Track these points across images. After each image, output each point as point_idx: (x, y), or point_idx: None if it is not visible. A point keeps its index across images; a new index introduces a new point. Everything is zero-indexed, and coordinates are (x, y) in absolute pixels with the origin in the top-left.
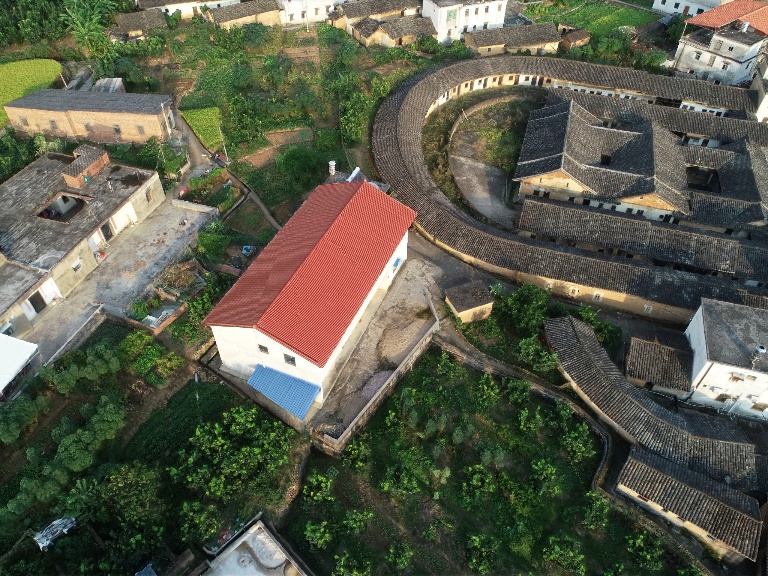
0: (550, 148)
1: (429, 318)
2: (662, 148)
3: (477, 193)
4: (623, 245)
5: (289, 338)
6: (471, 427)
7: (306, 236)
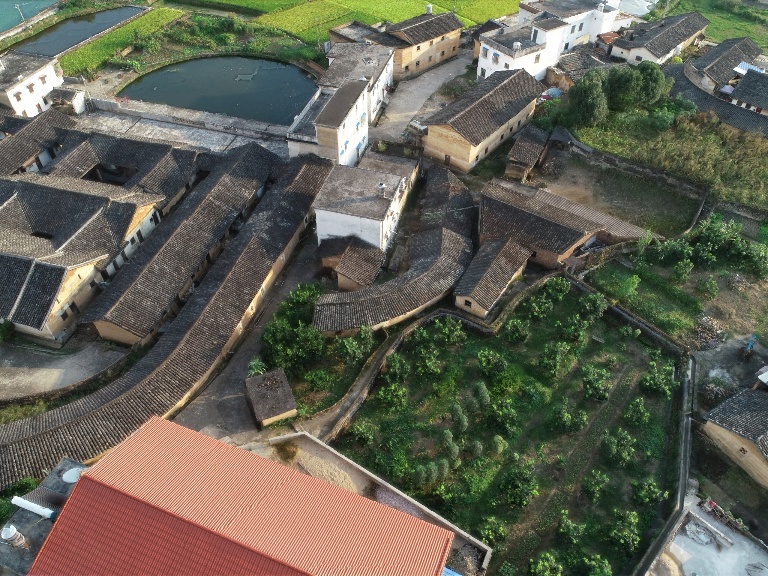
0: (7, 275)
1: (294, 445)
2: (54, 184)
3: (34, 382)
4: (202, 252)
5: (425, 575)
6: (458, 406)
7: (202, 572)
